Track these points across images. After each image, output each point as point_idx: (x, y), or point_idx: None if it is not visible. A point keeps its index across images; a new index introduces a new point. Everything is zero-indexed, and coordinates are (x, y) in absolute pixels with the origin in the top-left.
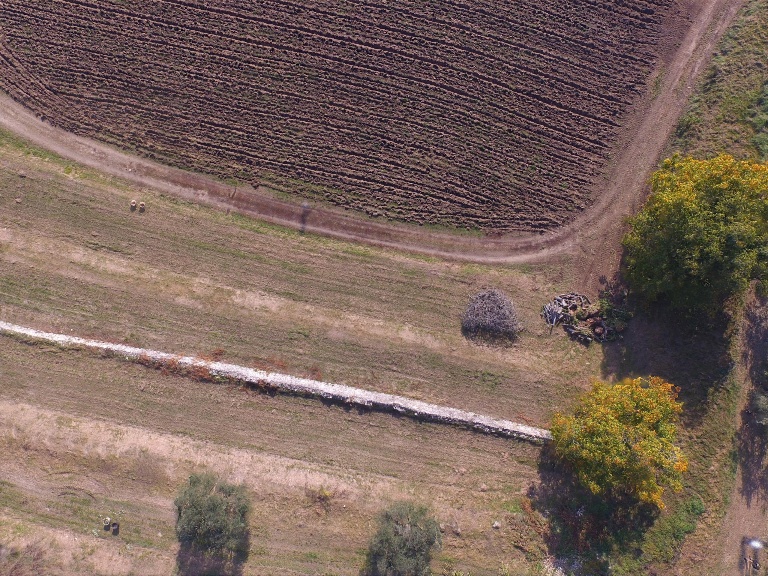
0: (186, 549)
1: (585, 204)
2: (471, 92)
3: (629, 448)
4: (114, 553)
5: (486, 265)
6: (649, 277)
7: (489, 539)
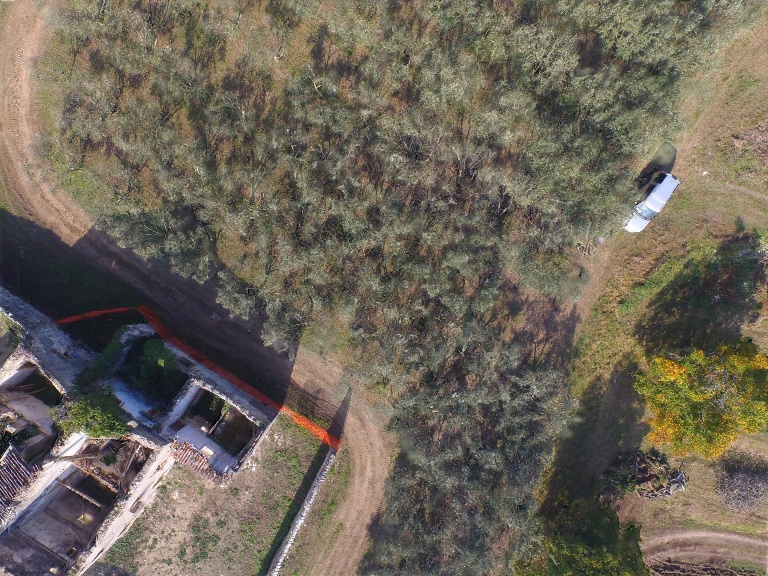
0: None
1: None
2: None
3: None
4: None
5: (728, 530)
6: None
7: None
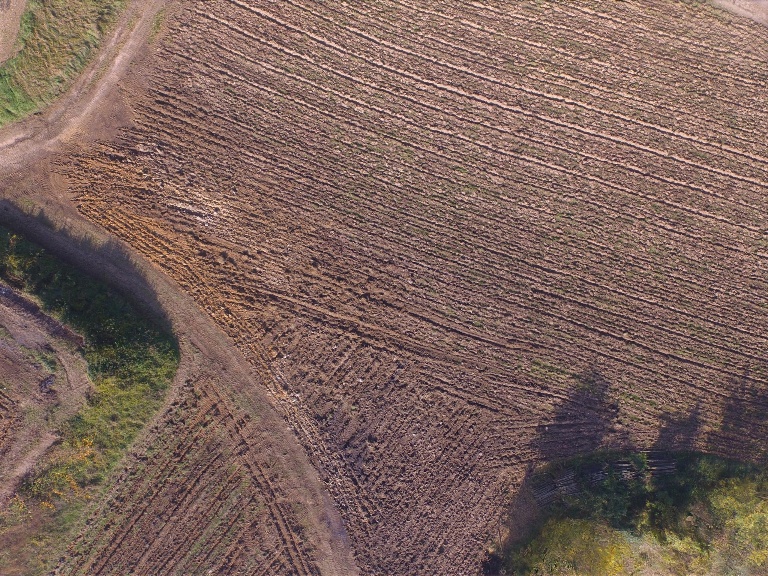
0: None
1: None
2: (348, 35)
3: None
4: None
5: None
6: None
7: None
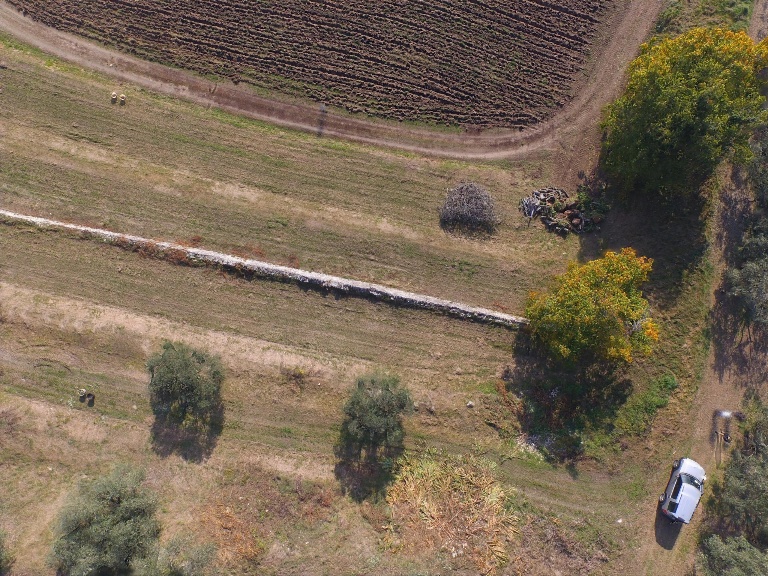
0: (161, 422)
1: (564, 100)
2: None
3: (598, 305)
4: (89, 423)
5: (465, 161)
6: (625, 161)
7: (463, 417)
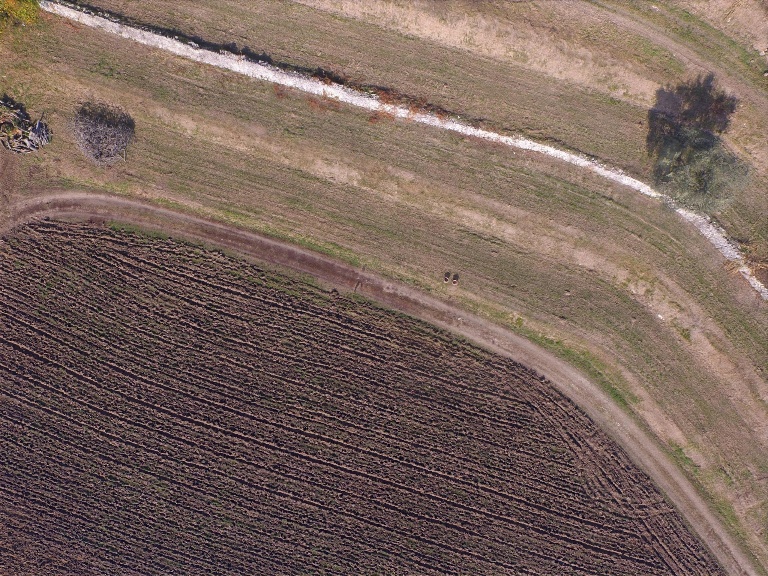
0: None
1: None
2: (106, 369)
3: None
4: None
5: (108, 192)
6: None
7: None
